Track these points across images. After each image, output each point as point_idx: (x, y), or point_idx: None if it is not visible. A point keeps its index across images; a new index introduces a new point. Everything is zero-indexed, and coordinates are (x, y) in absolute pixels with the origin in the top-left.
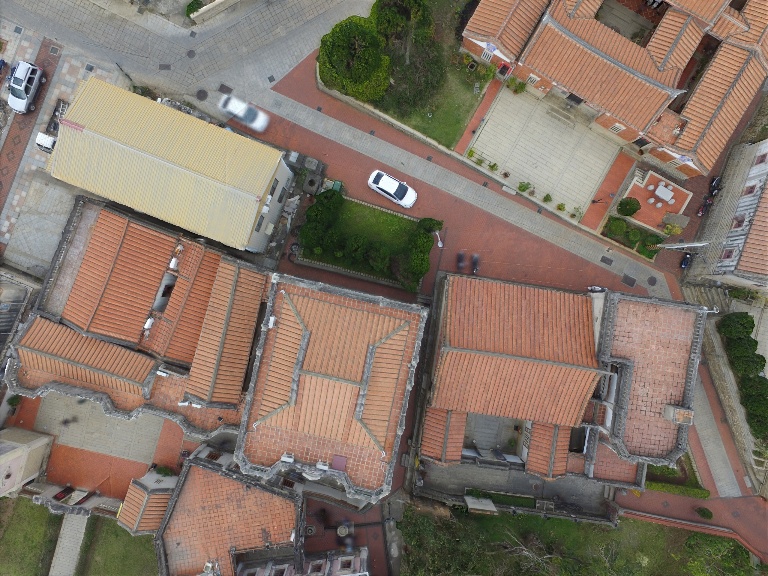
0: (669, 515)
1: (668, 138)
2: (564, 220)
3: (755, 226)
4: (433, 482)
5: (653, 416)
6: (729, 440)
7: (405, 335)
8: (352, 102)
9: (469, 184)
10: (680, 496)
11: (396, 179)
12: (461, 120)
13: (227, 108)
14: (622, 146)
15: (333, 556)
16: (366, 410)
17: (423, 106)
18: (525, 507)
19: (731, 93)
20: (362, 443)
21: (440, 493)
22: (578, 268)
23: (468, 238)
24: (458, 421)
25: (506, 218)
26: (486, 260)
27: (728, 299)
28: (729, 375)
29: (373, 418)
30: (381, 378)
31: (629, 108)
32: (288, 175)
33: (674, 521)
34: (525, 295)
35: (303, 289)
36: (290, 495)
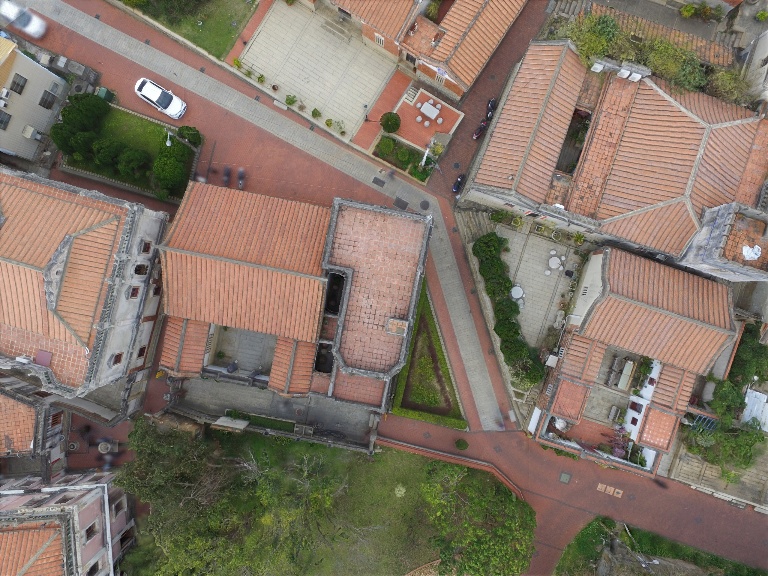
0: (430, 446)
1: (425, 50)
2: (336, 138)
3: (494, 138)
4: (194, 402)
5: (376, 329)
6: (496, 372)
7: (113, 229)
8: (126, 9)
9: (241, 97)
10: (443, 428)
11: (161, 87)
12: (233, 30)
13: (7, 13)
14: (397, 64)
15: (92, 472)
16: (63, 302)
17: (193, 14)
18: (283, 430)
19: (489, 4)
20: (64, 338)
21: (198, 412)
22: (349, 188)
23: (237, 153)
24: (197, 332)
25: (277, 134)
26: (255, 176)
27: (493, 224)
28: (486, 301)
29: (73, 311)
30: (82, 271)
31: (379, 14)
32: (52, 79)
33: (431, 451)
34: (267, 204)
35: (13, 178)
36: (32, 402)
